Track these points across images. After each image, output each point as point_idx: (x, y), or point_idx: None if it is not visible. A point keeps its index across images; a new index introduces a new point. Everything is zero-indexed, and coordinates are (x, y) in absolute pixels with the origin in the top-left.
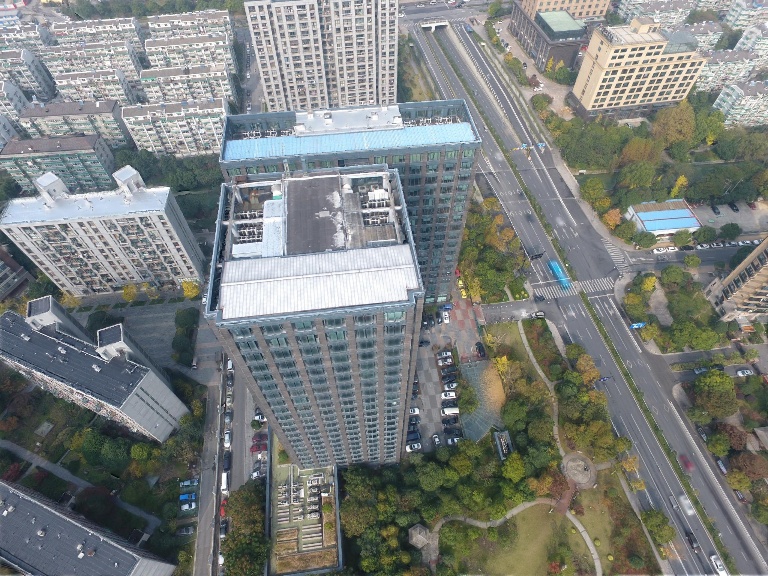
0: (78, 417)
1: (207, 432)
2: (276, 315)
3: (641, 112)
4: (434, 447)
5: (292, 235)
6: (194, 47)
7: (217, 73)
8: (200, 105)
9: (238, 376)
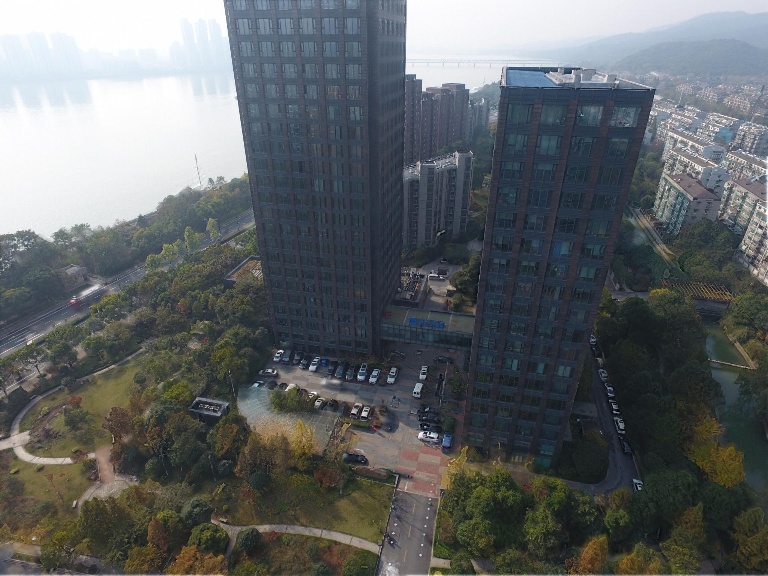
0: None
1: None
2: None
3: None
4: None
5: None
6: None
7: None
8: None
9: None
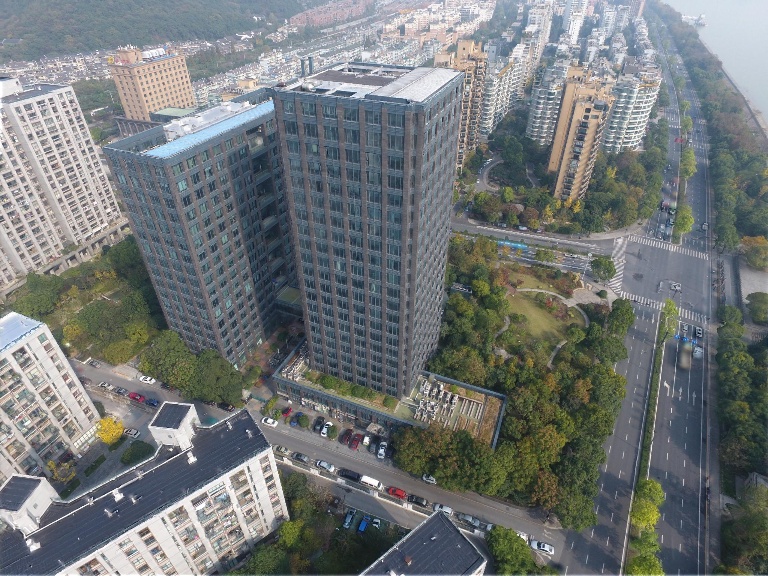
0: None
1: None
2: (435, 92)
3: None
4: None
5: None
6: None
7: None
8: None
9: None
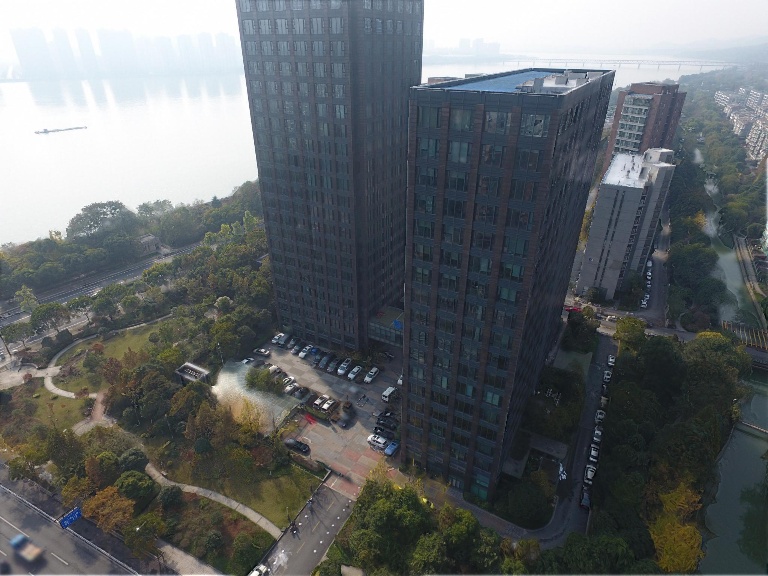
0: None
1: None
2: None
3: None
4: None
5: None
6: None
7: None
8: None
9: None
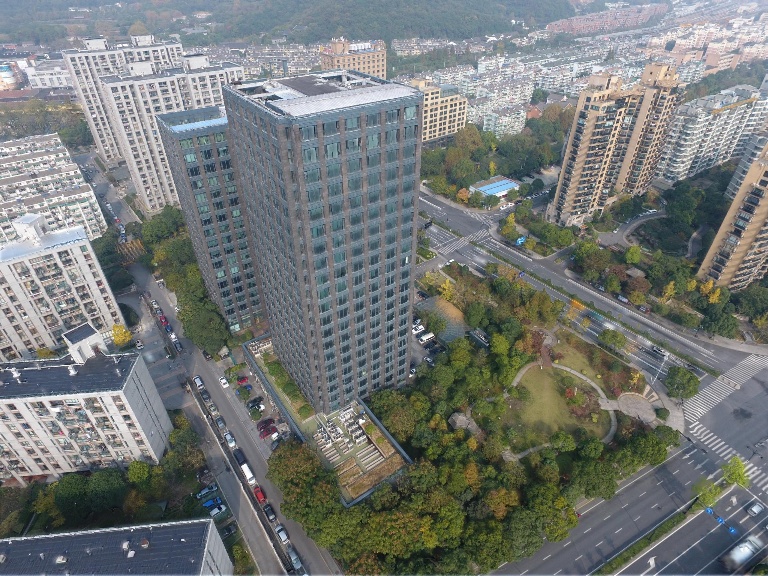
0: (23, 496)
1: (202, 444)
2: None
3: (442, 143)
4: (429, 366)
5: (305, 92)
6: (30, 163)
7: (69, 173)
8: (65, 193)
9: (211, 389)
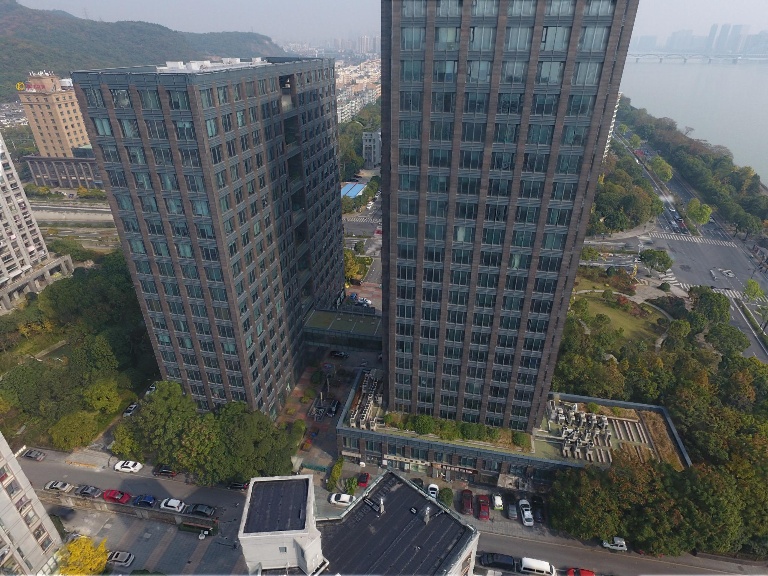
0: None
1: None
2: None
3: None
4: None
5: None
6: None
7: None
8: None
9: None
